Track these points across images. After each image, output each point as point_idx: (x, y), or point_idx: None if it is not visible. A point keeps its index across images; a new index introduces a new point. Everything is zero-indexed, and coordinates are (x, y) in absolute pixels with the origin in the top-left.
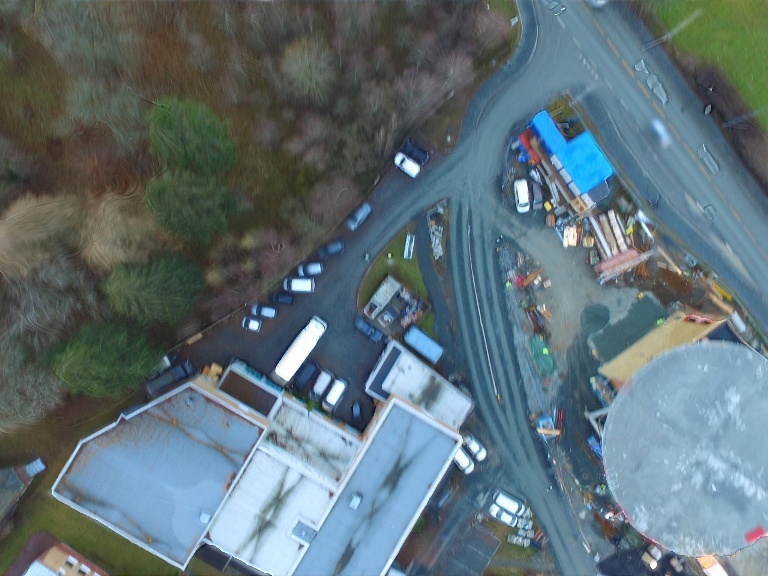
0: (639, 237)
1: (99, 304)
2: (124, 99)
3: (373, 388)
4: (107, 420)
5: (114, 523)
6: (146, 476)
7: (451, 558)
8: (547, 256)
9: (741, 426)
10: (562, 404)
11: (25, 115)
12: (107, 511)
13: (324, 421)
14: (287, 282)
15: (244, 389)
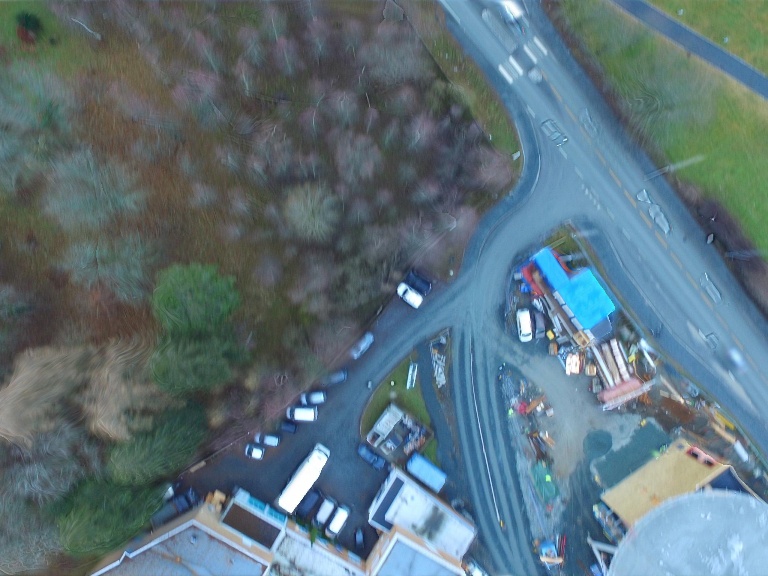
0: (641, 365)
1: (103, 470)
2: (128, 262)
3: (376, 519)
4: (111, 559)
5: None
6: None
7: None
8: (550, 383)
9: (744, 574)
10: (565, 530)
11: (28, 245)
12: None
13: (327, 552)
14: (290, 411)
15: (247, 522)
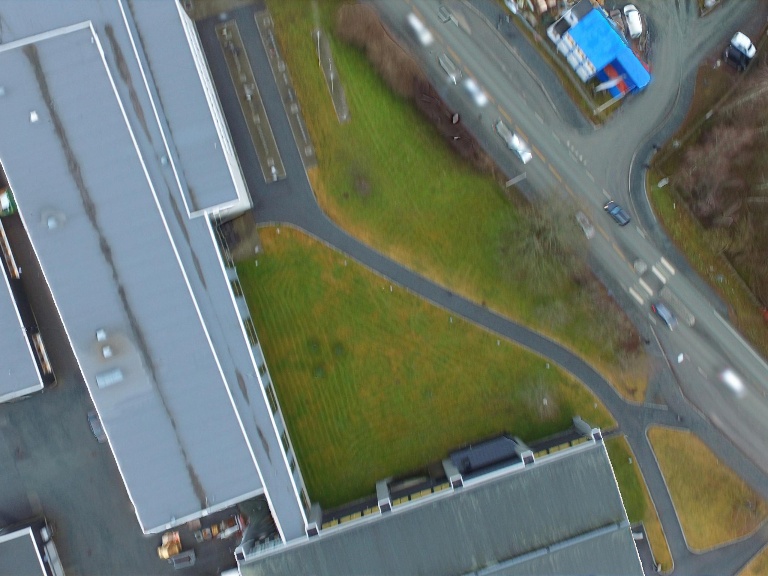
0: None
1: None
2: None
3: None
4: None
5: None
6: None
7: None
8: None
9: None
10: None
11: None
12: None
13: None
14: None
15: None
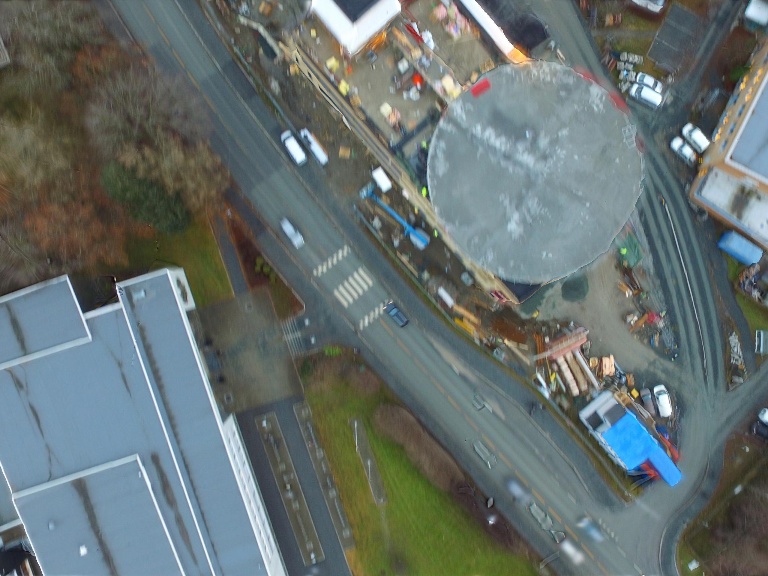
0: None
1: None
2: None
3: None
4: None
5: None
6: None
7: (694, 37)
8: (628, 344)
9: (505, 199)
10: None
11: None
12: None
13: None
14: None
15: None
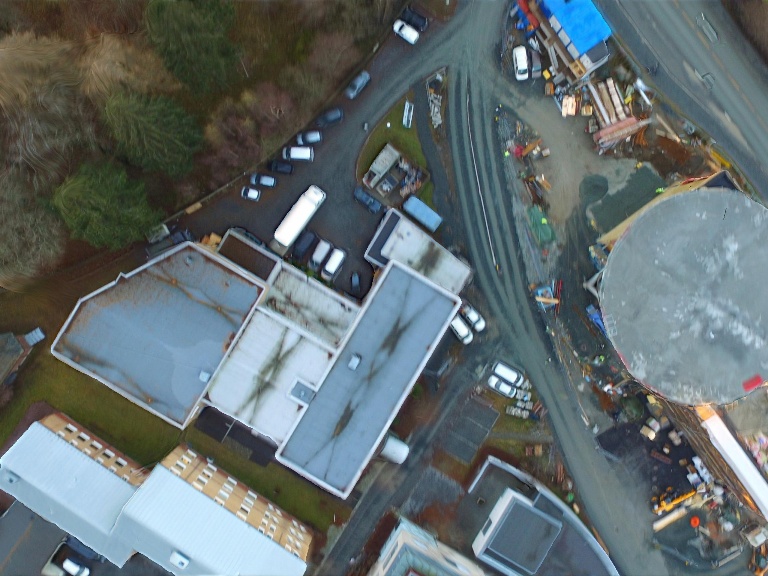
0: (638, 106)
1: (98, 135)
2: None
3: (372, 254)
4: (106, 278)
5: (113, 382)
6: (145, 335)
7: (450, 430)
8: (546, 126)
9: (739, 274)
10: (561, 275)
11: None
12: (106, 370)
13: (323, 286)
14: (286, 150)
15: (243, 253)
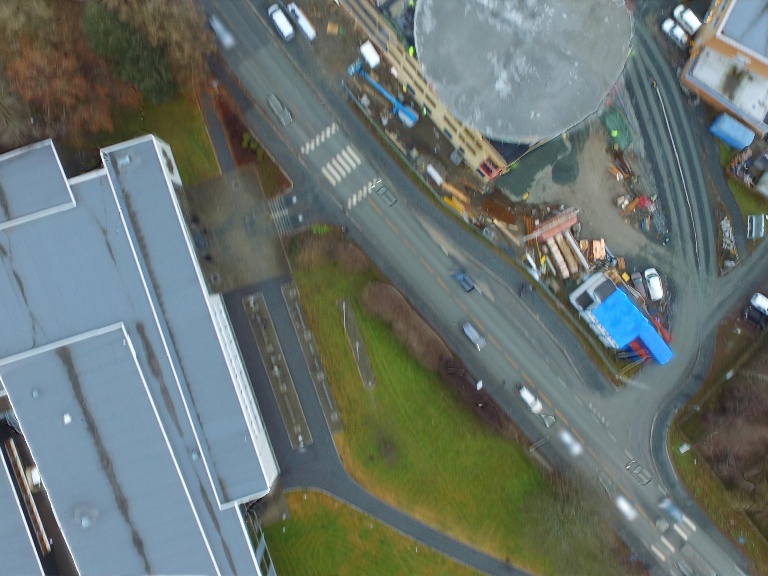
0: None
1: None
2: None
3: None
4: None
5: None
6: None
7: None
8: (619, 229)
9: (492, 57)
10: None
11: None
12: None
13: None
14: None
15: None
